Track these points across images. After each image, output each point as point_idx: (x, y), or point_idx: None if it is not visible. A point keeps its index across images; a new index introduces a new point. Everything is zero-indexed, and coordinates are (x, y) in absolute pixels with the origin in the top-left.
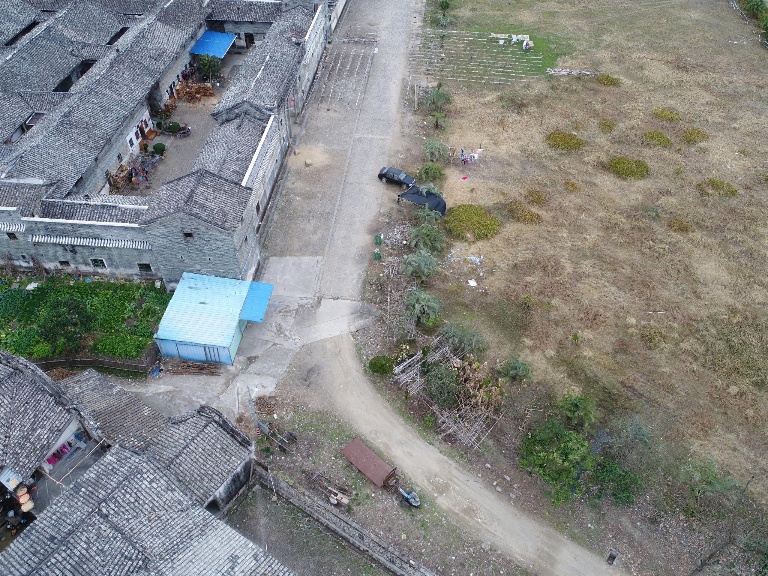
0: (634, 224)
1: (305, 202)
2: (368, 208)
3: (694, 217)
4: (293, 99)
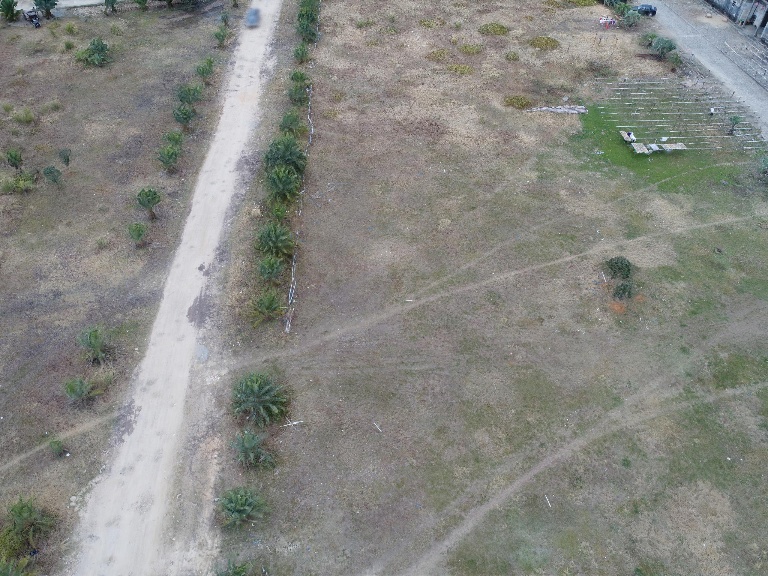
0: (489, 4)
1: (683, 1)
2: (645, 2)
3: (453, 7)
4: (761, 8)
